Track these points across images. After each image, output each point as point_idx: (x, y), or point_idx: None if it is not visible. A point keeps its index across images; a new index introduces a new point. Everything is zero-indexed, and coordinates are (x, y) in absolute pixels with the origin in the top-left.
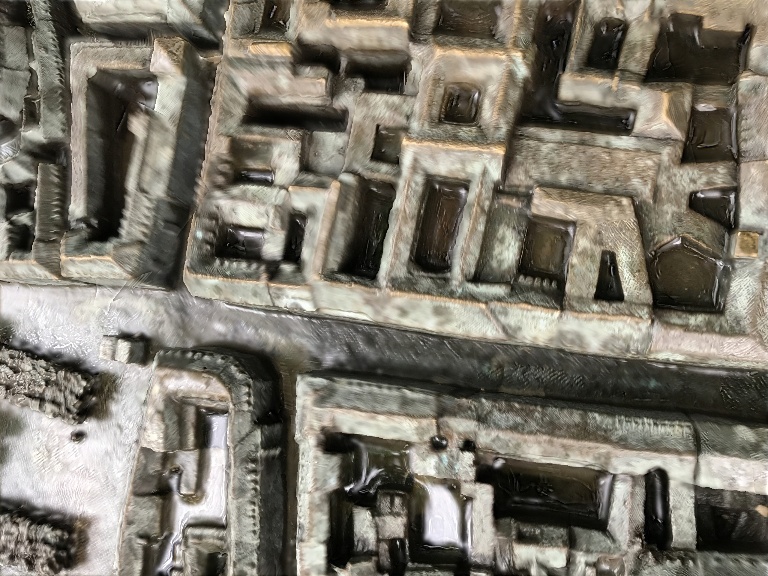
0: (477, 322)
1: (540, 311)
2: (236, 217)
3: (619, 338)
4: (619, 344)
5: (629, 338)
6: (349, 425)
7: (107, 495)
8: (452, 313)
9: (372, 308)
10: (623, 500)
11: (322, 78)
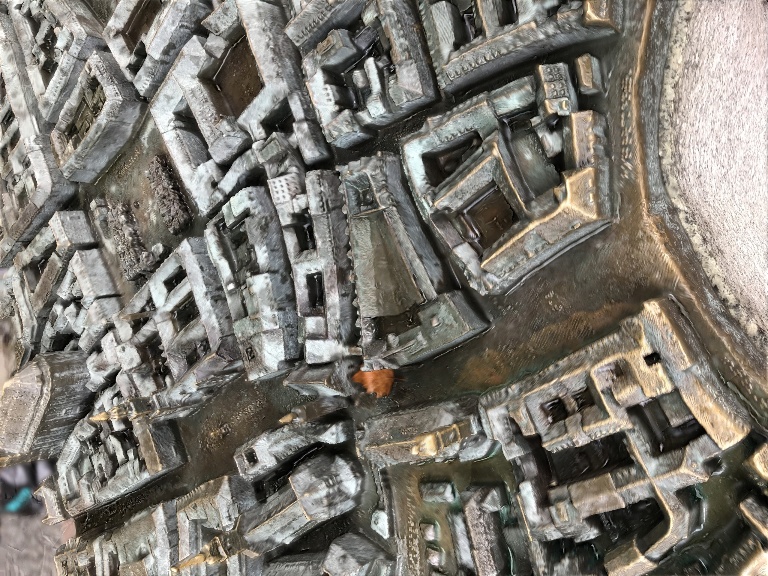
0: (13, 84)
1: (3, 71)
2: (33, 189)
3: (4, 48)
4: (6, 47)
5: (3, 46)
6: (41, 90)
7: (141, 168)
8: (13, 92)
9: (26, 117)
10: (24, 7)
11: (2, 195)
